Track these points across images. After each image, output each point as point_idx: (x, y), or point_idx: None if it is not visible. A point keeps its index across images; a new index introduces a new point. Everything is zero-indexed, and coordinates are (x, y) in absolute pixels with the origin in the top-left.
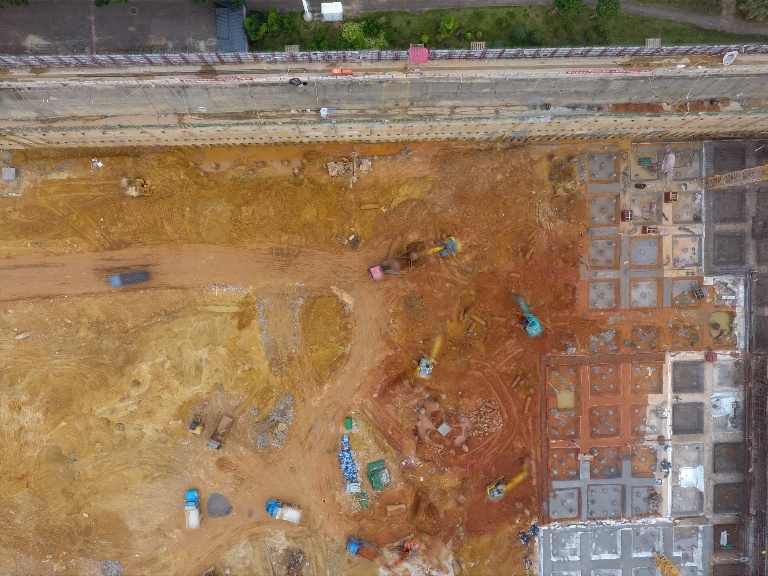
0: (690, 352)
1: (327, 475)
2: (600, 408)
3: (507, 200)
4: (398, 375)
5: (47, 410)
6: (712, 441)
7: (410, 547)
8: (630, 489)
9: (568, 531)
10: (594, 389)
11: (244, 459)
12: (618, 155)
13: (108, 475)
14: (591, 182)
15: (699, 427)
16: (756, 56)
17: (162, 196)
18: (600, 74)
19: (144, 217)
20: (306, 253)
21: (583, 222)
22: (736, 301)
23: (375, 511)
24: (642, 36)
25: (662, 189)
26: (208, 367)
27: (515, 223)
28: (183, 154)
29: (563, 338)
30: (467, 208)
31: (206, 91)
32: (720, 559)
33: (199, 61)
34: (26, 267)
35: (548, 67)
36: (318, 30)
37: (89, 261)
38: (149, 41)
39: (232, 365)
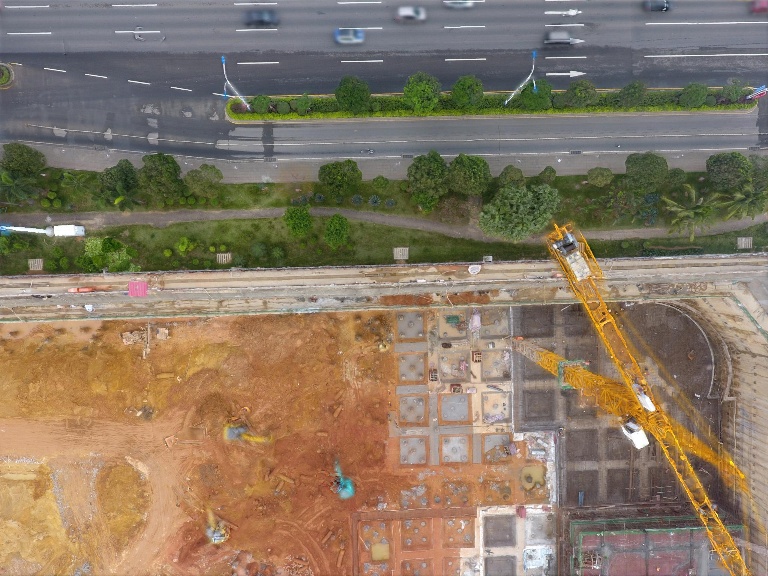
0: (501, 506)
1: None
2: (413, 561)
3: (304, 368)
4: (201, 537)
5: None
6: None
7: None
8: None
9: None
10: (407, 542)
11: None
12: (425, 314)
13: None
14: (399, 341)
15: None
16: (503, 265)
17: None
18: (345, 285)
19: None
20: (99, 424)
21: (391, 380)
22: (548, 455)
23: None
24: (390, 245)
25: (470, 347)
26: None
27: (314, 389)
28: None
29: (374, 493)
30: (258, 381)
31: None
32: None
33: None
34: None
35: (294, 278)
36: (55, 249)
37: None
38: None
39: (26, 535)
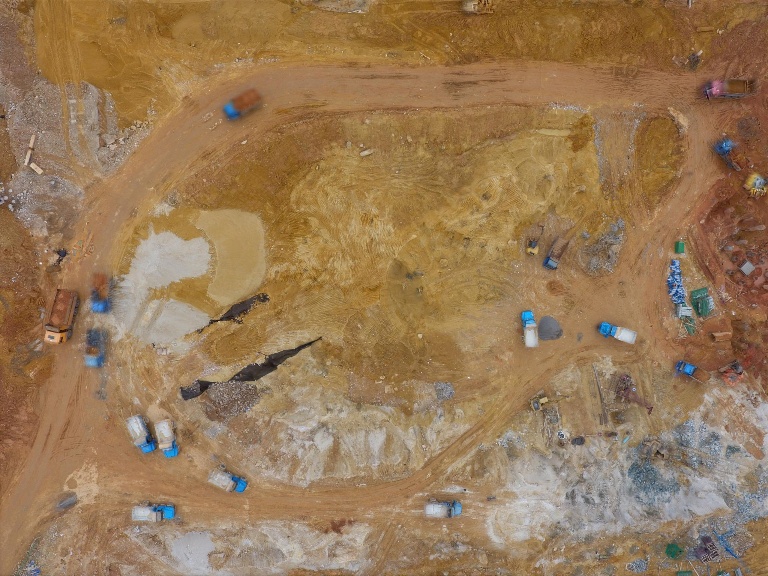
0: None
1: (655, 300)
2: None
3: None
4: (720, 204)
5: (394, 225)
6: None
7: None
8: None
9: None
10: None
11: (575, 282)
12: None
13: (450, 292)
14: None
15: None
16: None
17: (505, 14)
18: None
19: (489, 34)
20: (645, 73)
21: None
22: None
23: (701, 337)
24: None
25: None
26: (555, 182)
27: None
28: None
29: None
30: None
31: None
32: None
33: None
34: (383, 77)
35: None
36: None
37: (440, 74)
38: None
39: (568, 186)
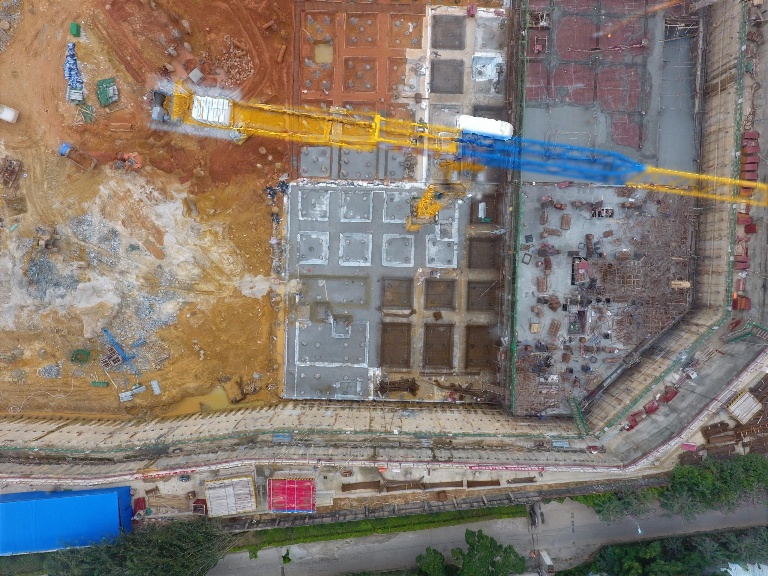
0: (452, 6)
1: (51, 84)
2: (357, 62)
3: None
4: None
5: None
6: (472, 103)
7: (127, 158)
8: (384, 148)
9: (318, 190)
10: (352, 41)
11: None
12: None
13: None
14: None
15: (460, 89)
16: None
17: None
18: None
19: None
20: None
21: None
22: None
23: (99, 126)
24: None
25: None
26: None
27: None
28: None
29: None
30: None
31: None
32: (476, 231)
33: None
34: None
35: None
36: None
37: None
38: None
39: None
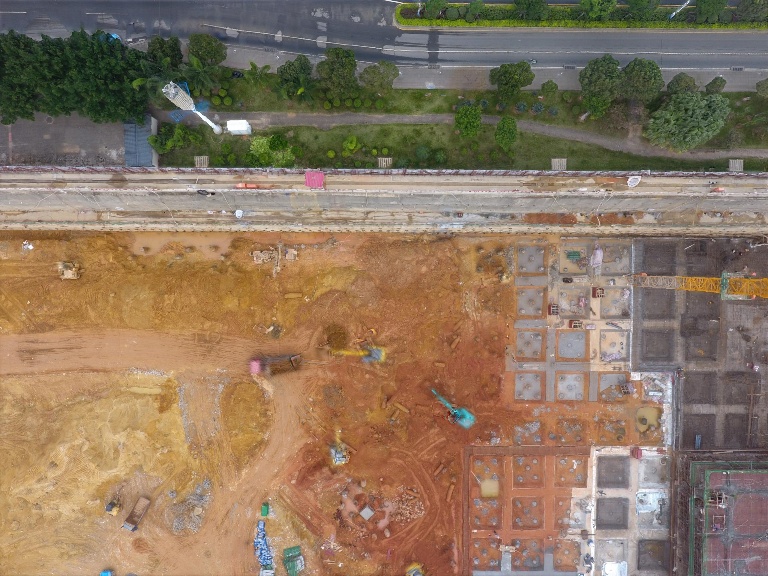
0: (616, 447)
1: (242, 560)
2: (524, 499)
3: (430, 294)
4: (318, 461)
5: None
6: (636, 537)
7: None
8: None
9: None
10: (518, 480)
11: (160, 541)
12: (547, 248)
13: (23, 553)
14: (519, 274)
15: (624, 522)
16: (661, 179)
17: (89, 280)
18: (504, 193)
19: (70, 300)
20: (228, 340)
21: (510, 314)
22: (664, 397)
23: None
24: (548, 156)
25: (590, 284)
26: (125, 451)
27: (438, 316)
28: (113, 238)
29: (487, 428)
30: (387, 302)
31: (117, 197)
32: None
33: (110, 170)
34: None
35: (453, 184)
36: (225, 145)
37: (14, 343)
38: (63, 149)
39: (151, 448)
